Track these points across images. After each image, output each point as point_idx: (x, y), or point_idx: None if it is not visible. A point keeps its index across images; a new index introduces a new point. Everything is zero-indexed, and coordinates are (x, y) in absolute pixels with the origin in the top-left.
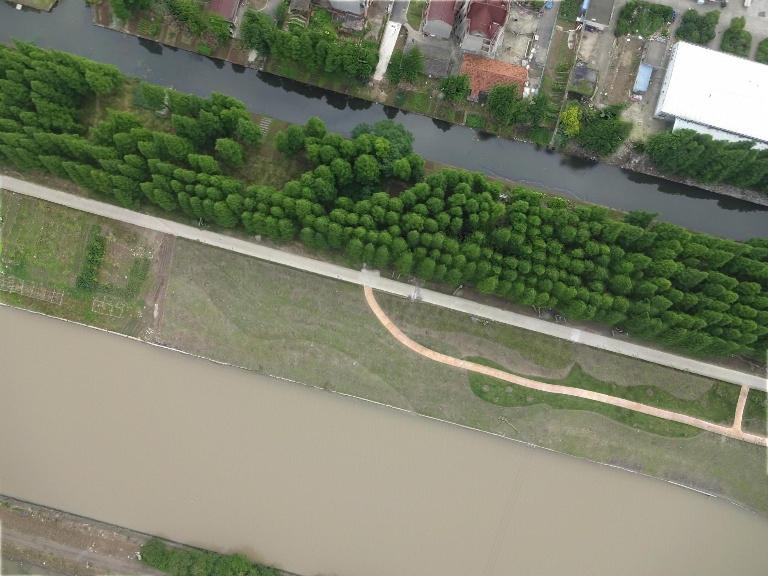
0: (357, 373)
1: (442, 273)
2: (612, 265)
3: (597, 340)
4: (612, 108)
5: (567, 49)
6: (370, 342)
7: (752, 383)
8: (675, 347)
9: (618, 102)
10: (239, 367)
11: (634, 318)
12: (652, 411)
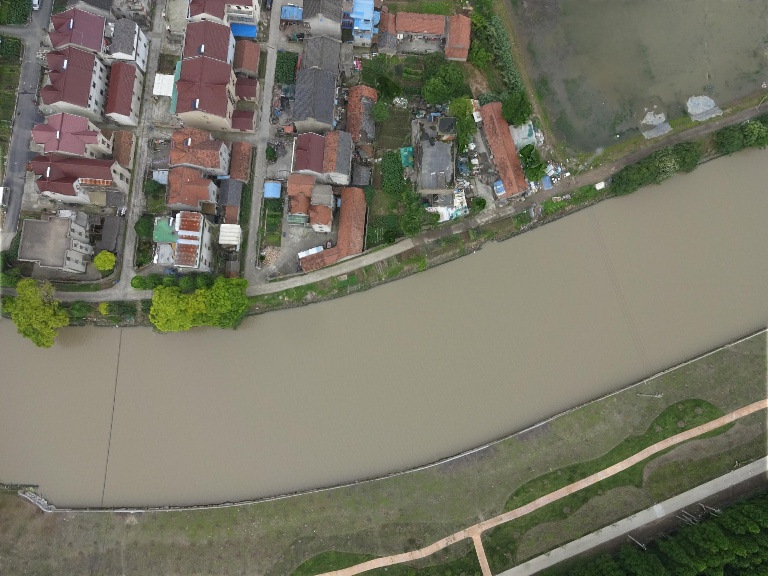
0: None
1: None
2: None
3: (639, 521)
4: None
5: None
6: None
7: None
8: (580, 567)
9: None
10: None
11: (663, 568)
12: (555, 496)
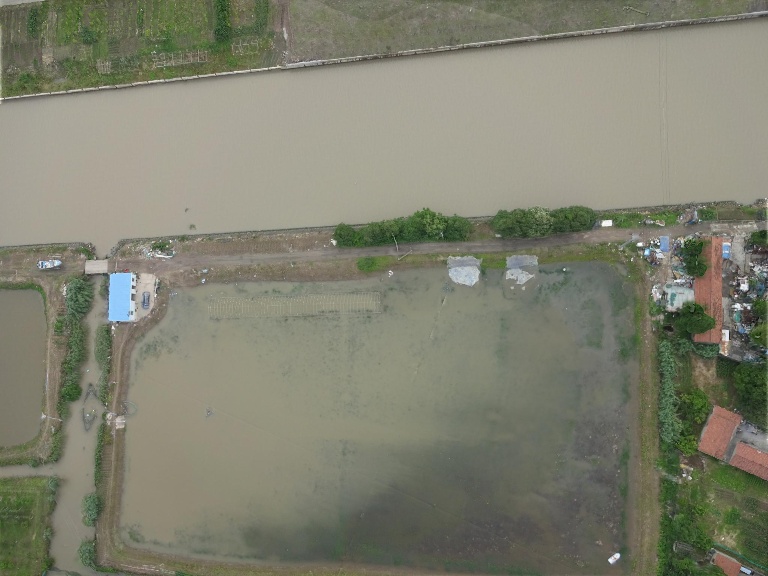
0: (476, 18)
1: None
2: None
3: None
4: None
5: None
6: None
7: None
8: None
9: None
10: (369, 59)
11: None
12: None
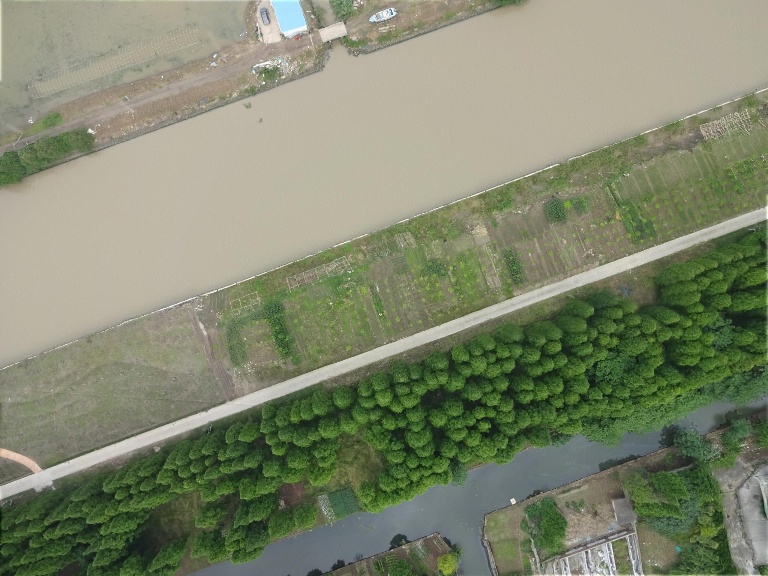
0: (4, 392)
1: None
2: None
3: None
4: None
5: None
6: (6, 427)
7: None
8: None
9: None
10: None
11: None
12: None
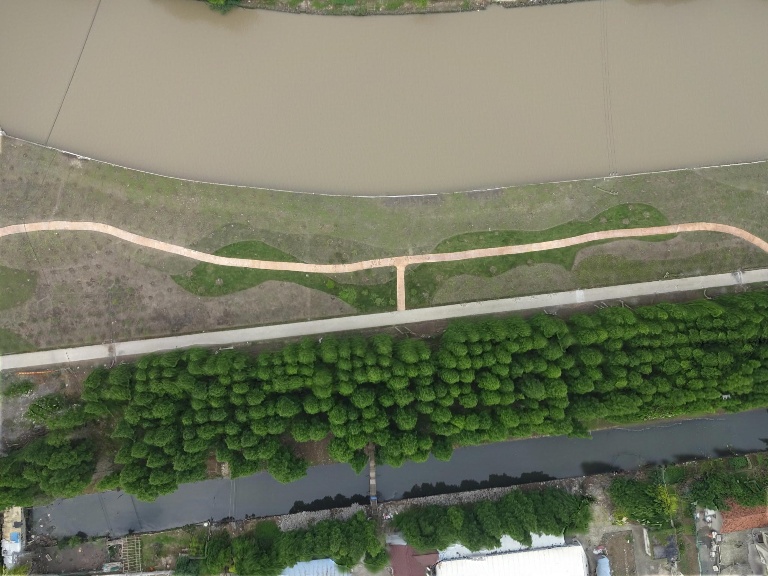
0: (760, 185)
1: (759, 300)
2: (605, 371)
3: (559, 300)
4: (618, 530)
5: (682, 570)
6: (763, 216)
7: (397, 317)
8: None
9: (614, 539)
10: None
11: None
12: (487, 253)
